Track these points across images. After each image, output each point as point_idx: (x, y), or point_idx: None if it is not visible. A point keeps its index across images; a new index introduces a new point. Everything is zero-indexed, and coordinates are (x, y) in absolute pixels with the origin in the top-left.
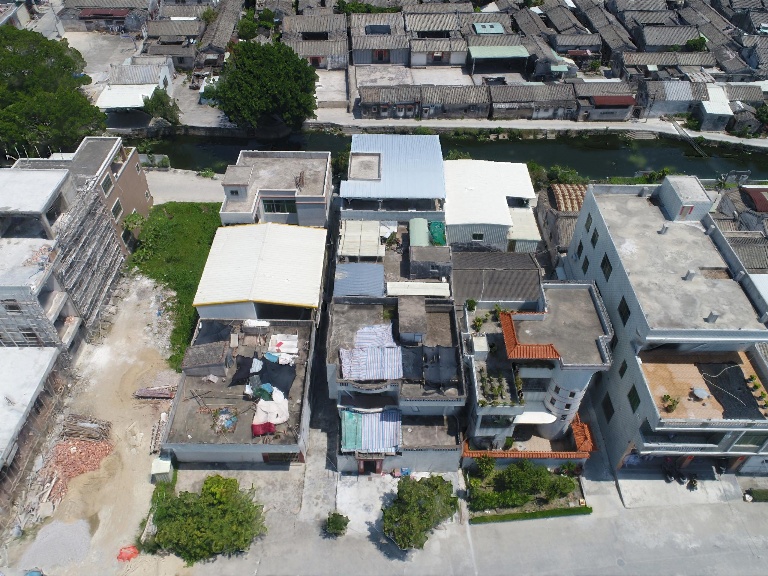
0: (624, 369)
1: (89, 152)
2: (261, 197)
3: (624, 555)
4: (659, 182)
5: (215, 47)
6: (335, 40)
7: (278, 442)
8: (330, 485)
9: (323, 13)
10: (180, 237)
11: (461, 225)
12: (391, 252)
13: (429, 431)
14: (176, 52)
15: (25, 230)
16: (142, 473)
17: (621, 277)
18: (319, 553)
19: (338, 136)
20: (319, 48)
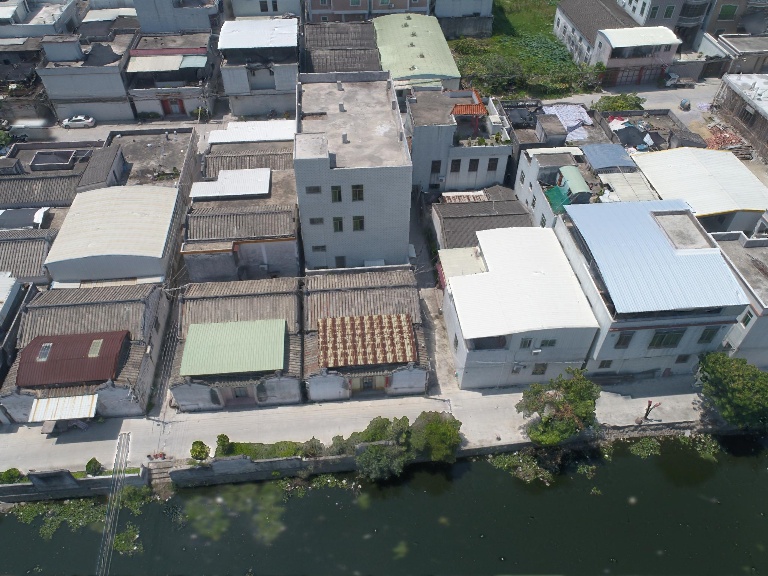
0: None
1: None
2: None
3: None
4: None
5: None
6: None
7: None
8: None
9: None
10: None
11: None
12: None
13: None
14: None
15: None
16: None
17: None
18: None
19: None
20: None
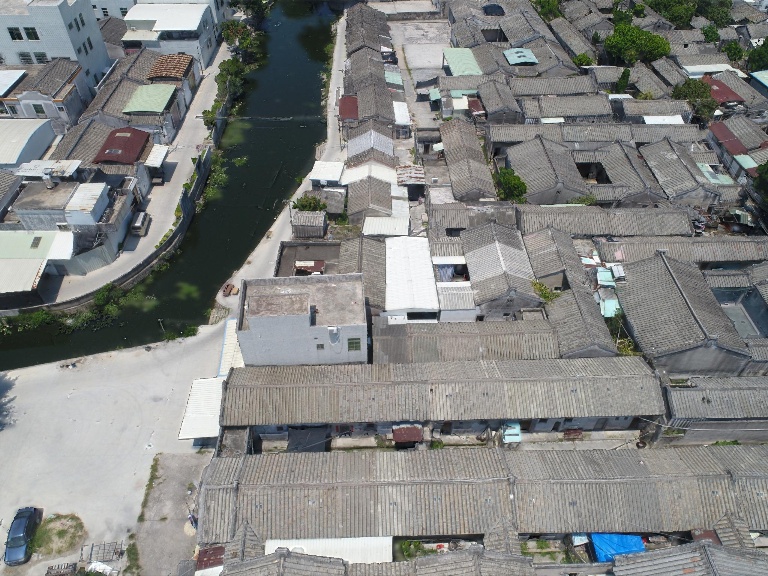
0: None
1: None
2: None
3: None
4: None
5: None
6: None
7: None
8: None
9: None
10: None
11: None
12: None
13: None
14: None
15: None
16: None
17: None
18: None
19: None
20: None
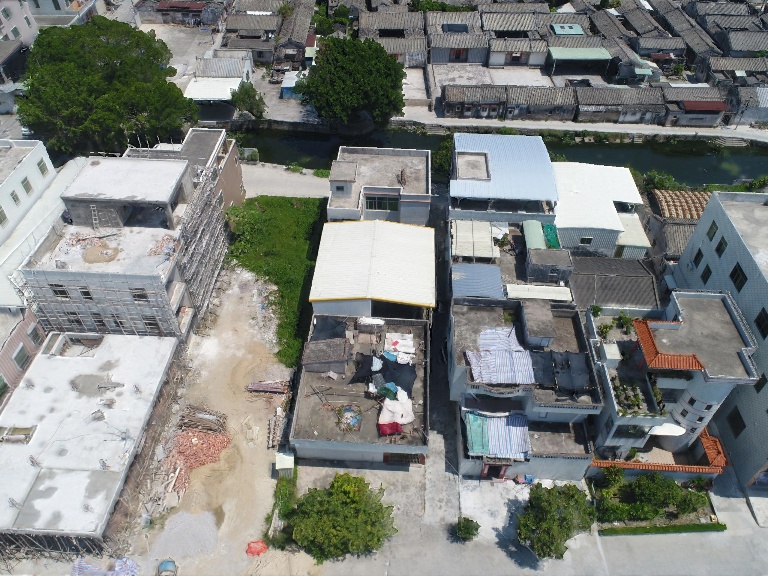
0: (763, 383)
1: (195, 143)
2: (365, 194)
3: (764, 575)
4: (758, 191)
5: (295, 42)
6: (414, 38)
7: (405, 443)
8: (452, 488)
9: (398, 10)
10: (275, 231)
11: (571, 229)
12: (504, 254)
13: (556, 438)
14: (256, 46)
15: (146, 219)
16: (262, 467)
17: (761, 288)
18: (448, 557)
19: (421, 134)
20: (398, 45)
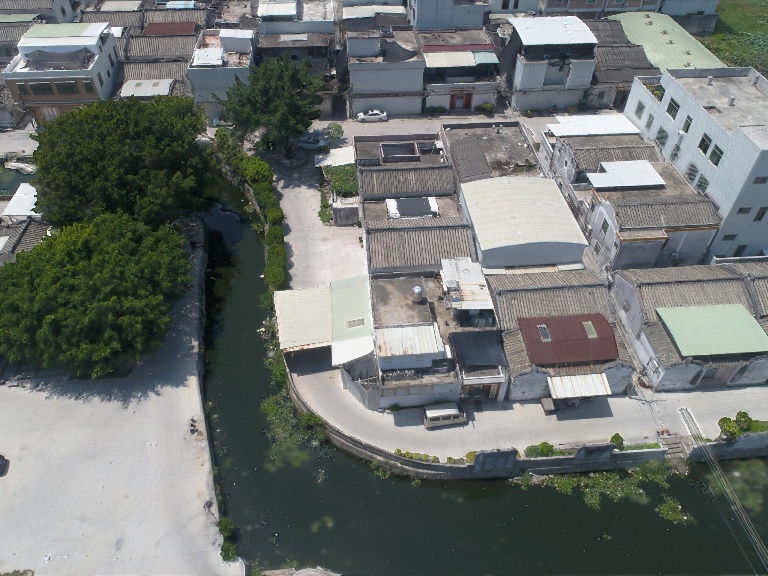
0: None
1: None
2: None
3: None
4: None
5: None
6: None
7: None
8: None
9: None
10: None
11: None
12: None
13: None
14: None
15: None
16: None
17: None
18: None
19: None
20: None
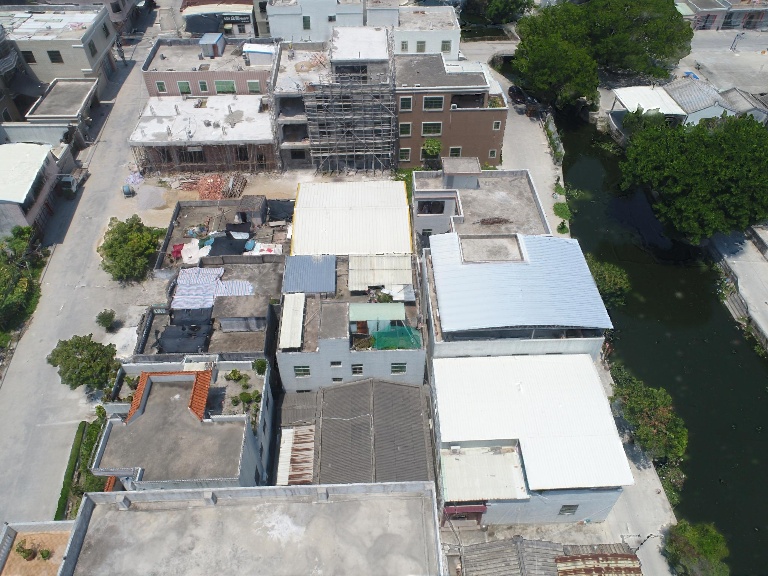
0: None
1: (464, 78)
2: None
3: None
4: None
5: None
6: None
7: (168, 262)
8: None
9: None
10: None
11: None
12: None
13: None
14: None
15: None
16: None
17: None
18: None
19: (717, 294)
20: None
